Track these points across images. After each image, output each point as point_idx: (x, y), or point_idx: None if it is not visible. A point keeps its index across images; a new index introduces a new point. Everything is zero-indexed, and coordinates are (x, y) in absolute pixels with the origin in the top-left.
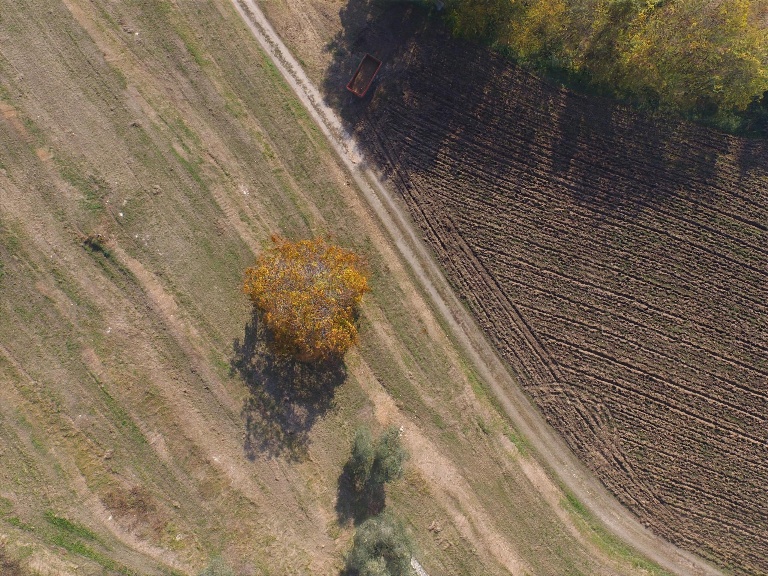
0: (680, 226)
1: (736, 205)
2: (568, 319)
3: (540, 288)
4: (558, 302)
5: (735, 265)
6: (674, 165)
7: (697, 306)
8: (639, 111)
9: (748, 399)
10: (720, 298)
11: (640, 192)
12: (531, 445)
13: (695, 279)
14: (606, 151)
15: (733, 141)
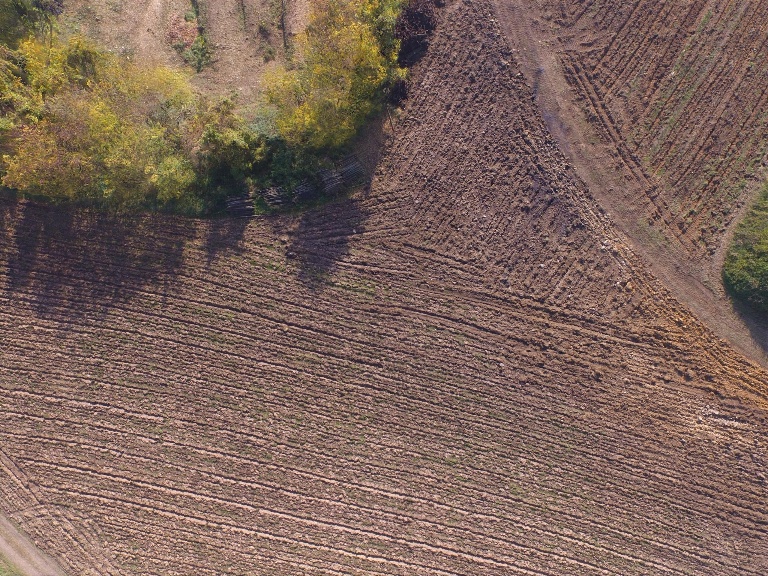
0: (151, 322)
1: (207, 291)
2: (44, 438)
3: (12, 411)
4: (32, 422)
5: (211, 353)
6: (140, 260)
7: (177, 402)
8: (102, 210)
9: (237, 489)
10: (199, 390)
11: (107, 294)
12: (22, 573)
13: (172, 374)
14: (69, 257)
15: (201, 225)
